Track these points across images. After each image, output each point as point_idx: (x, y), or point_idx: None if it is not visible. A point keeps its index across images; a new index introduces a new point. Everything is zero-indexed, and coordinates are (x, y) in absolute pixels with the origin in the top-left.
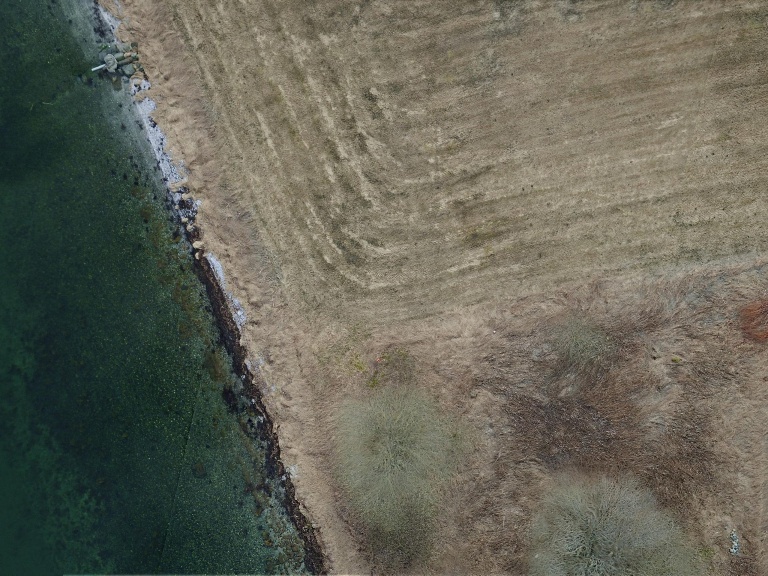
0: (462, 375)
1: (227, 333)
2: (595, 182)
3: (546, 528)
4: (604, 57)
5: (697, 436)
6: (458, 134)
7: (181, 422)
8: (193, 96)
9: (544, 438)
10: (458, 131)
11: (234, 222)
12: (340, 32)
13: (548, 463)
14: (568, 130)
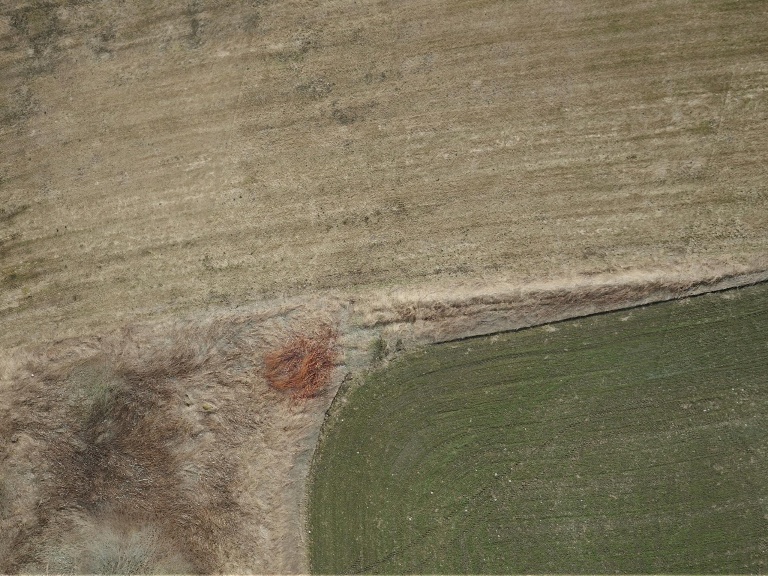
0: (2, 419)
1: None
2: (125, 224)
3: None
4: (134, 96)
5: (225, 486)
6: None
7: None
8: None
9: (84, 485)
10: None
11: None
12: None
13: (89, 510)
14: (98, 170)
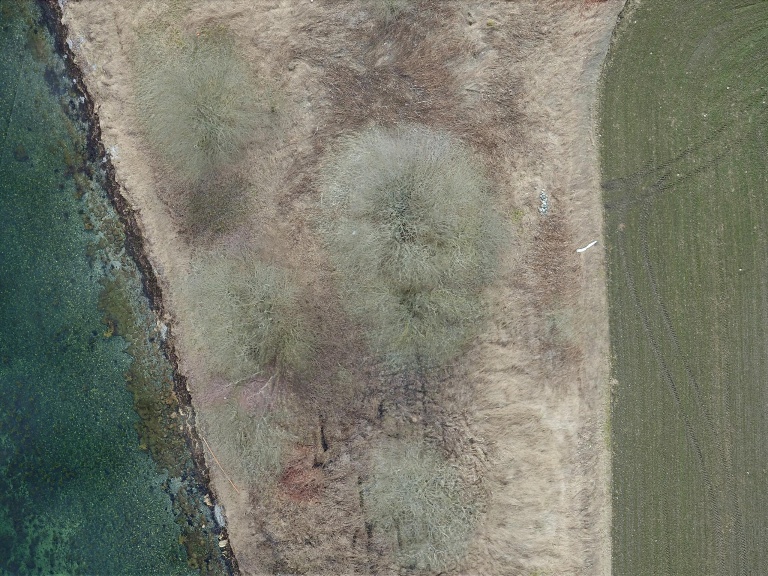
0: (280, 46)
1: (49, 12)
2: None
3: (364, 204)
4: None
5: (510, 99)
6: None
7: (3, 104)
8: None
9: (361, 110)
10: None
11: None
12: None
13: (366, 137)
14: None
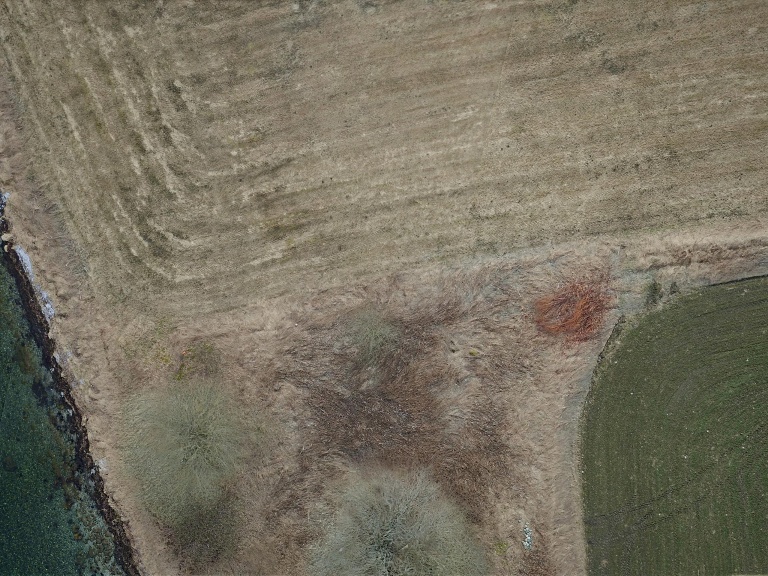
0: (265, 368)
1: (36, 326)
2: (392, 175)
3: (350, 522)
4: (401, 49)
5: (494, 429)
6: (259, 126)
7: None
8: (0, 88)
9: (347, 431)
10: (259, 123)
11: (41, 214)
12: (144, 24)
13: (351, 456)
14: (365, 122)
